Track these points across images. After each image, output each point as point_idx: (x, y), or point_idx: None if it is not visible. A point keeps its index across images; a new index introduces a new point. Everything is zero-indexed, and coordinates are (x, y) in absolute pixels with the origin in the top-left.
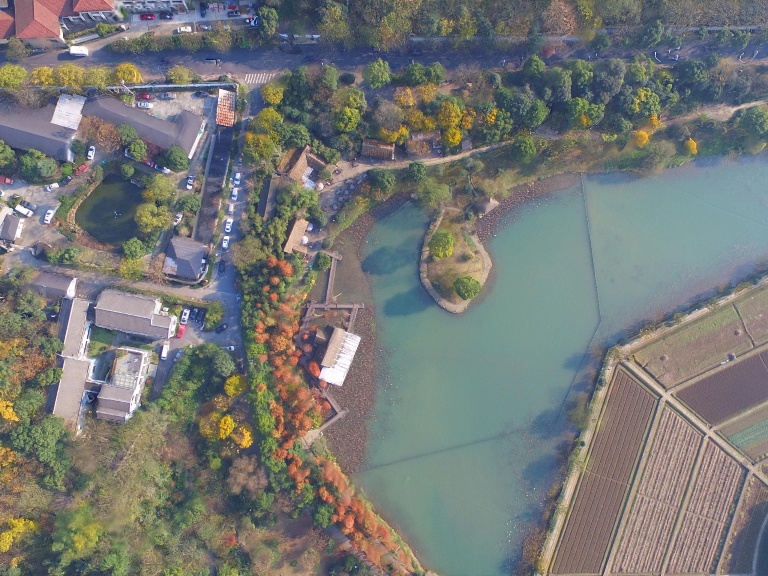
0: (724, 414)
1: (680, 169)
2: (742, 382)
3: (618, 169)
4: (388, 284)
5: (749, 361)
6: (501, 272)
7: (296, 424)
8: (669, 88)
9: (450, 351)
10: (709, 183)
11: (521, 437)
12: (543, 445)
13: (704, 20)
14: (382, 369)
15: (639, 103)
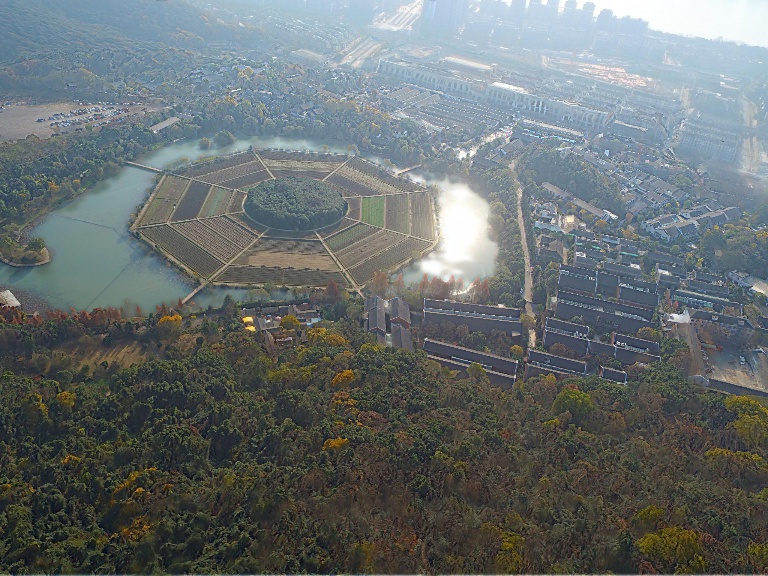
0: (195, 214)
1: (85, 193)
2: (188, 206)
3: (60, 204)
4: (1, 277)
5: (182, 202)
6: (51, 245)
7: (8, 310)
8: (46, 177)
9: (63, 272)
10: (101, 189)
11: (132, 265)
12: (145, 261)
13: (32, 159)
14: (36, 294)
15: (39, 183)
